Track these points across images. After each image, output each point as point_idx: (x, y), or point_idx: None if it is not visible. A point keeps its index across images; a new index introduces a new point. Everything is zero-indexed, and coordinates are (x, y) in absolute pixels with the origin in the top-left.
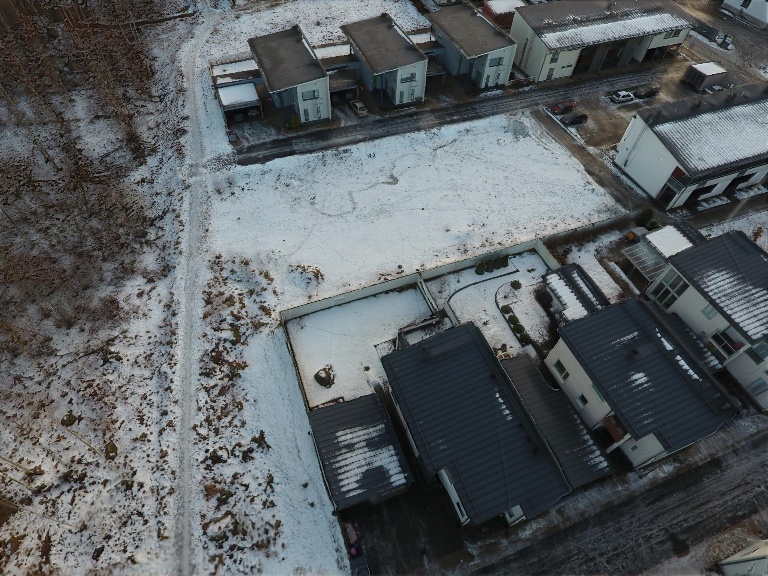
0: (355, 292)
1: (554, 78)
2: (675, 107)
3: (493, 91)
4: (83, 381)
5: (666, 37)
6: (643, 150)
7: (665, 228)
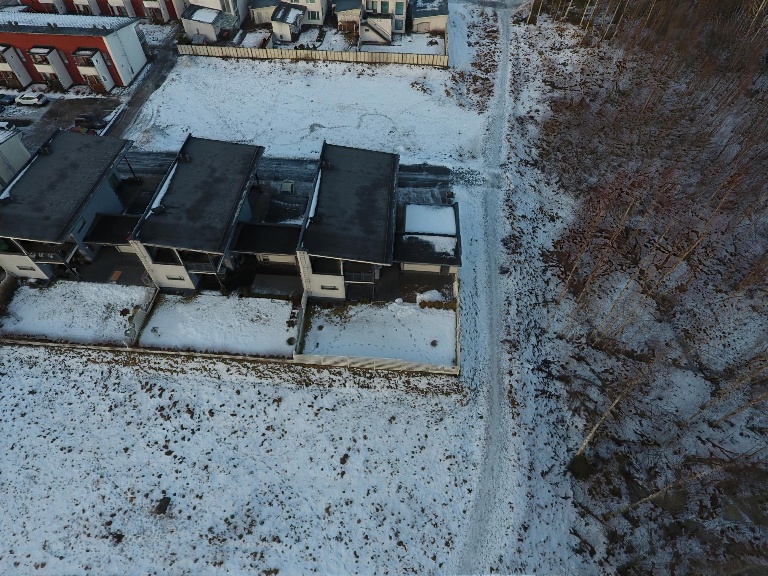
0: (400, 53)
1: None
2: (70, 32)
3: None
4: (562, 75)
5: None
6: None
7: (197, 19)
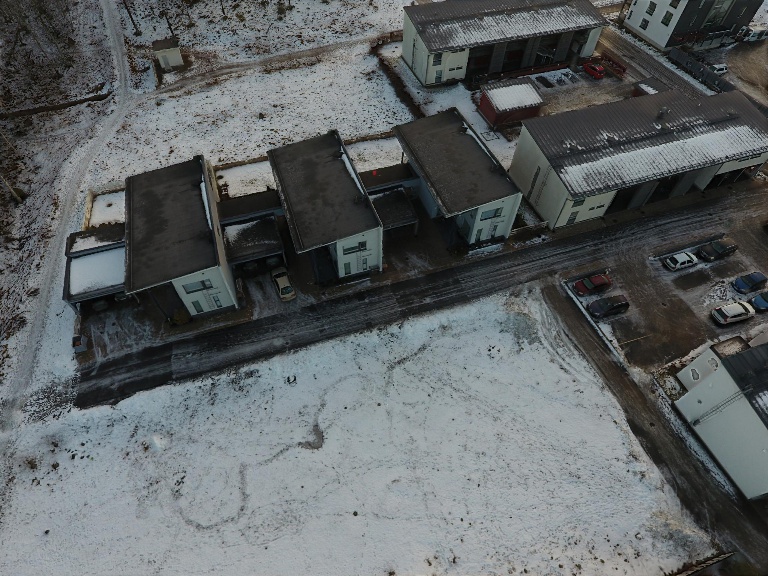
0: None
1: (578, 221)
2: None
3: (488, 246)
4: None
5: (743, 159)
6: (730, 419)
7: None
